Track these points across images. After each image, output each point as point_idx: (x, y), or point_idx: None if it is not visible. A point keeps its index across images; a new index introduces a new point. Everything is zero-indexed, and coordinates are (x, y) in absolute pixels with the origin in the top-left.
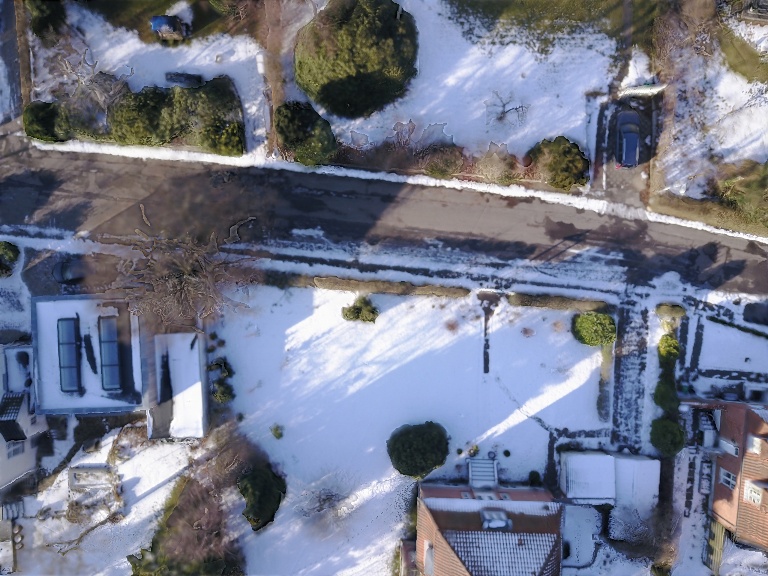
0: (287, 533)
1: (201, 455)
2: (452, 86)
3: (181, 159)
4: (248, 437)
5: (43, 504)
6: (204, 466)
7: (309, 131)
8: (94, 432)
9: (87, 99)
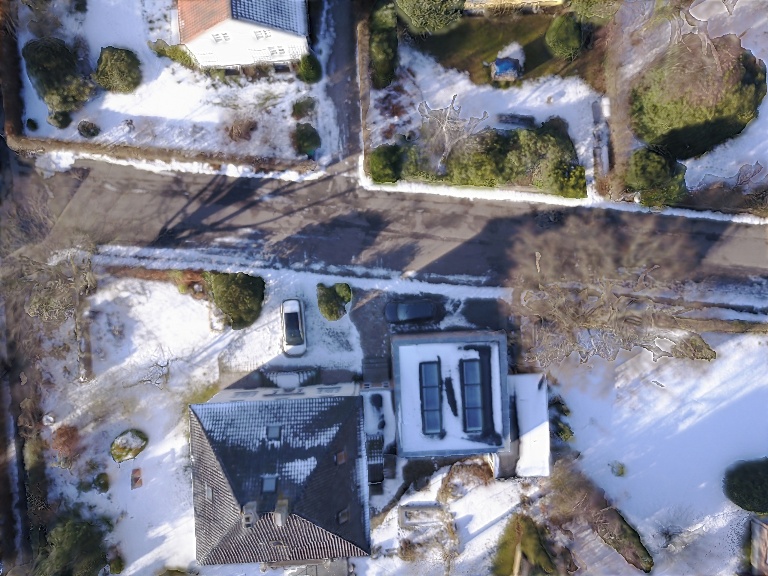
0: (623, 568)
1: (534, 492)
2: None
3: (507, 199)
4: (582, 474)
5: (374, 542)
6: (536, 503)
7: (674, 175)
8: (423, 470)
9: (436, 142)
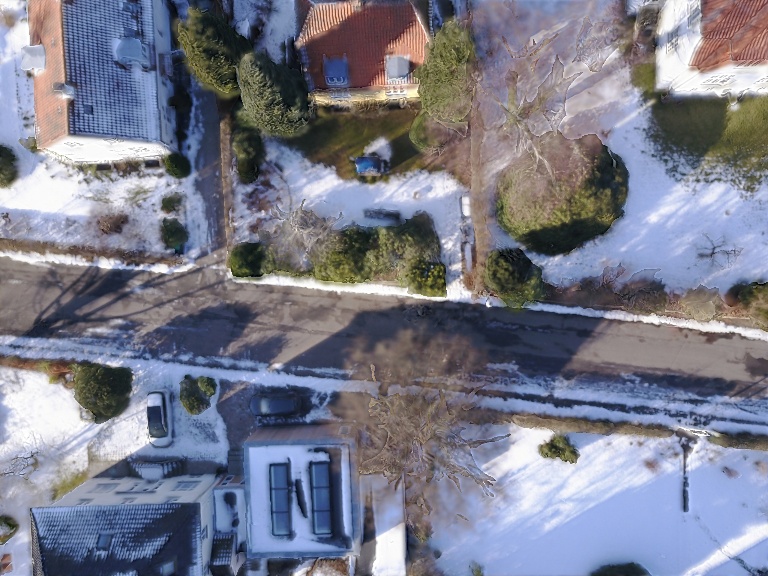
0: None
1: None
2: (654, 223)
3: (375, 292)
4: (445, 573)
5: None
6: None
7: (525, 281)
8: (288, 563)
9: (294, 241)
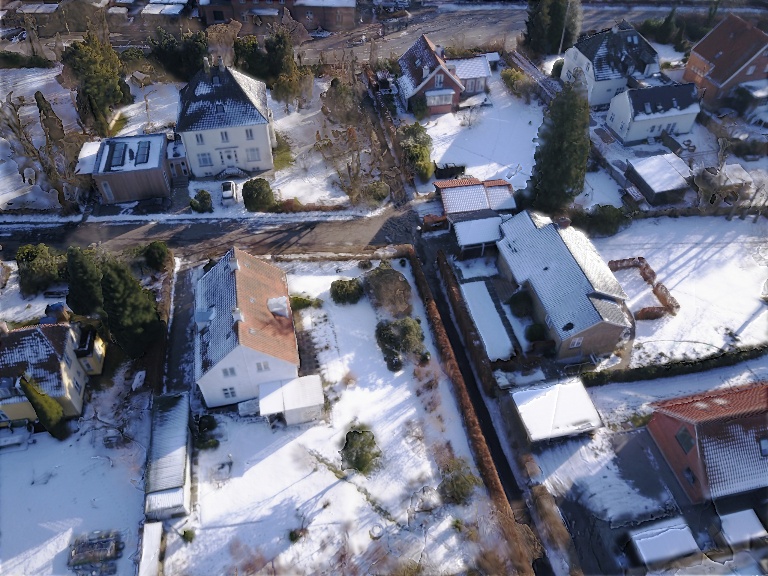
0: None
1: None
2: None
3: None
4: None
5: None
6: None
7: None
8: None
9: None
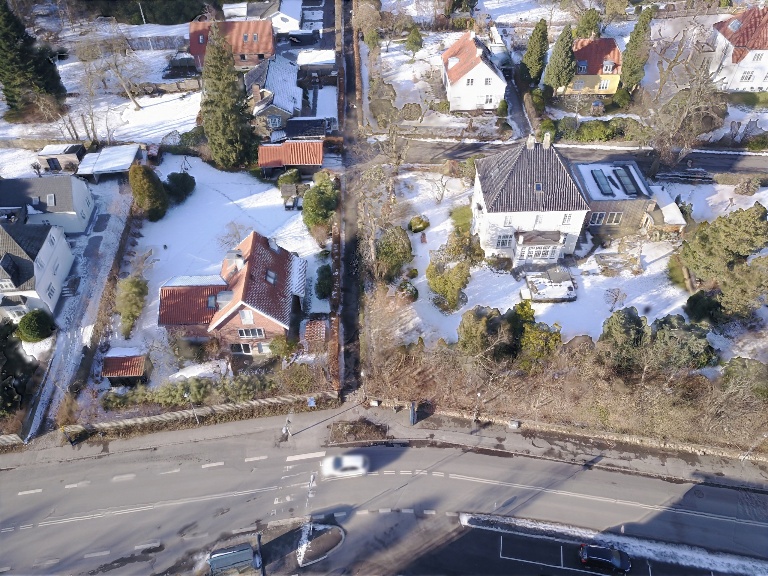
0: None
1: None
2: (745, 124)
3: (614, 149)
4: None
5: (583, 270)
6: None
7: None
8: None
9: (572, 119)
